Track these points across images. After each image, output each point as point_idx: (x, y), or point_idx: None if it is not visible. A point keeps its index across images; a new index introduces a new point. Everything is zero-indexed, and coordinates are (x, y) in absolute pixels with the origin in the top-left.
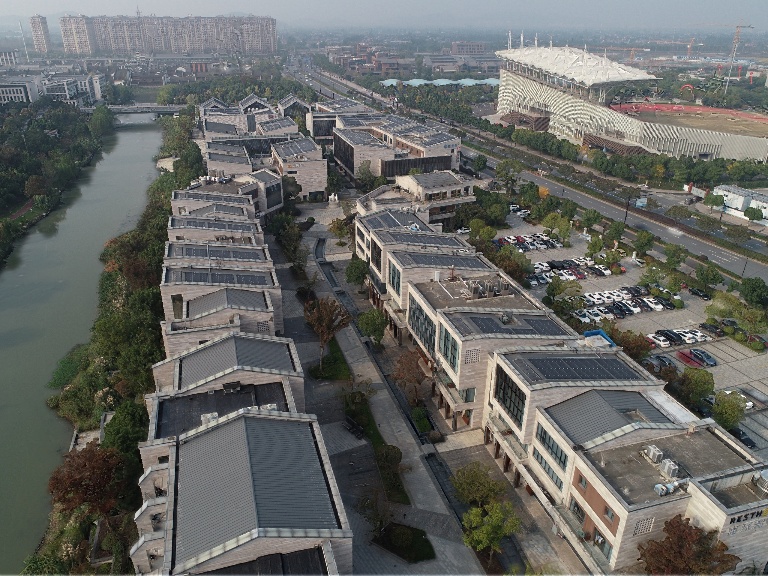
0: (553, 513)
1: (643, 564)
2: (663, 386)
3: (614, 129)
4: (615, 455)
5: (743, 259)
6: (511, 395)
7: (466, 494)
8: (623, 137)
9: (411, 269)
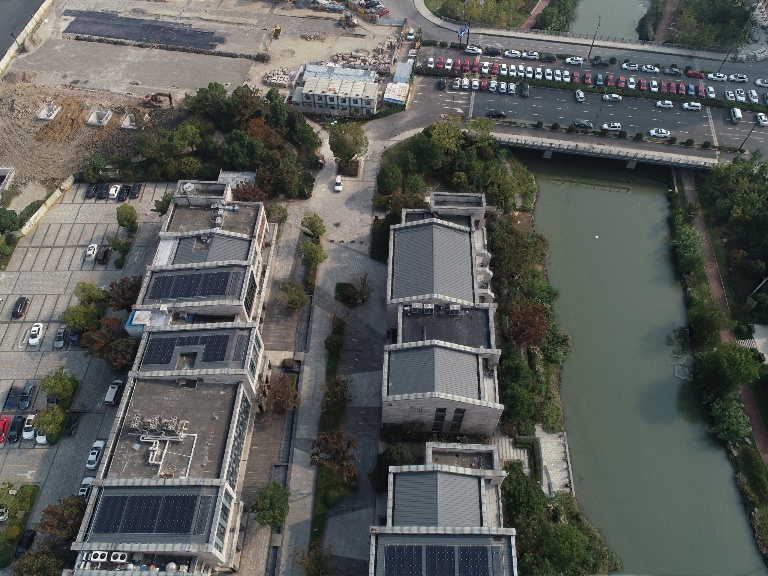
0: None
1: None
2: None
3: None
4: None
5: None
6: None
7: None
8: None
9: None
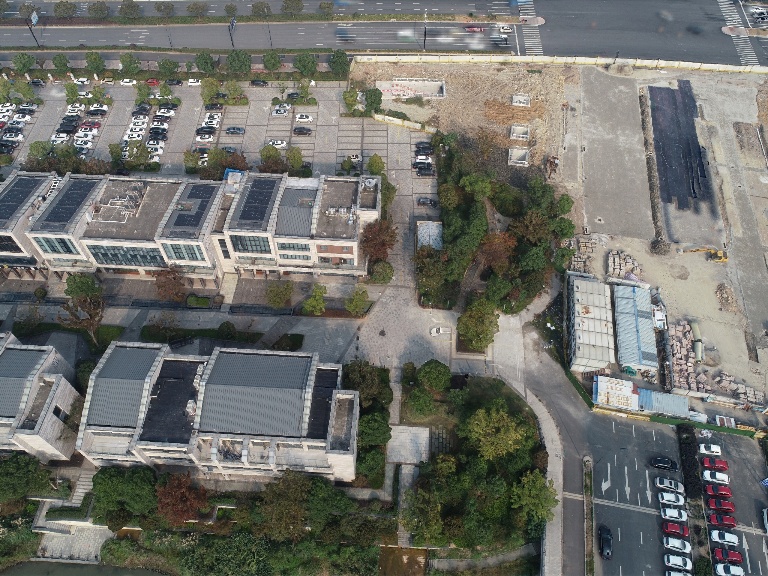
0: (316, 271)
1: (359, 253)
2: (287, 175)
3: None
4: (322, 226)
5: (150, 29)
6: (251, 243)
7: (281, 302)
8: None
9: (75, 230)
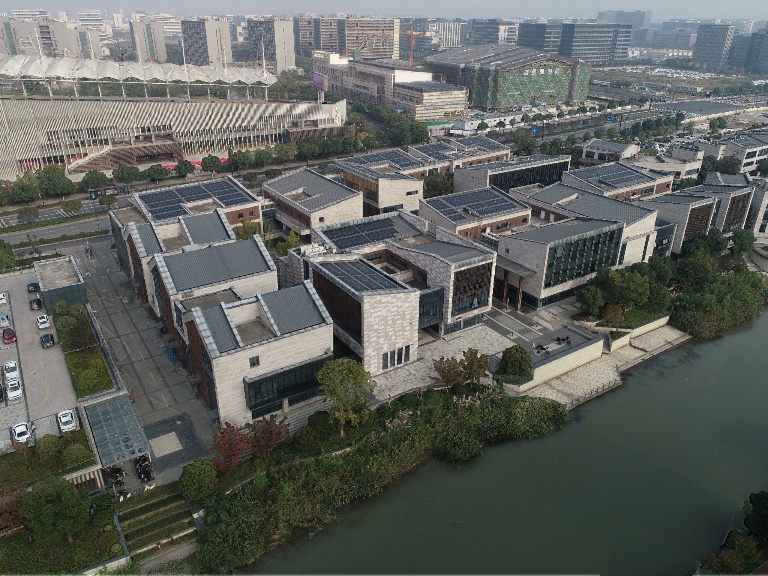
0: None
1: None
2: None
3: (301, 120)
4: None
5: None
6: None
7: None
8: (297, 127)
9: None
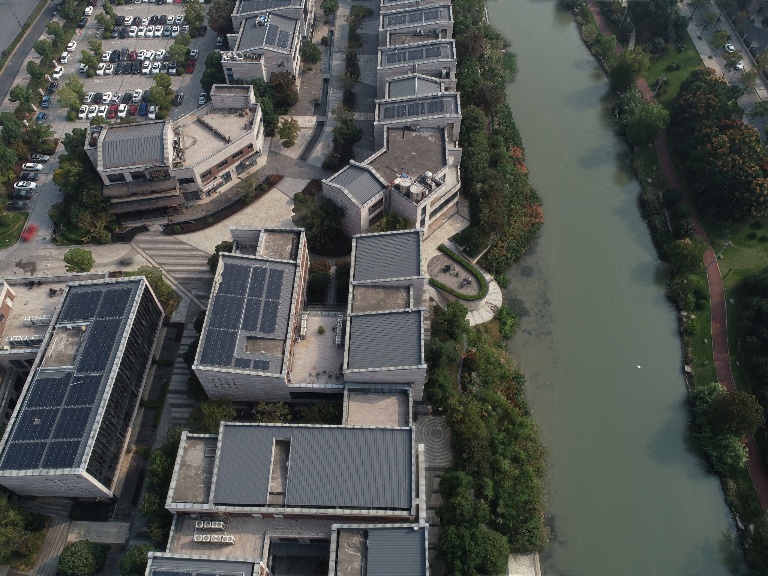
0: None
1: None
2: None
3: None
4: None
5: None
6: None
7: None
8: None
9: None
